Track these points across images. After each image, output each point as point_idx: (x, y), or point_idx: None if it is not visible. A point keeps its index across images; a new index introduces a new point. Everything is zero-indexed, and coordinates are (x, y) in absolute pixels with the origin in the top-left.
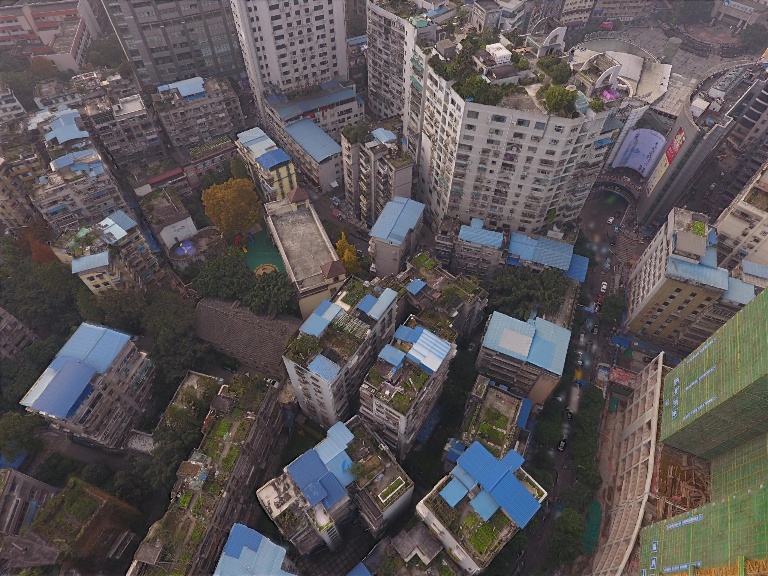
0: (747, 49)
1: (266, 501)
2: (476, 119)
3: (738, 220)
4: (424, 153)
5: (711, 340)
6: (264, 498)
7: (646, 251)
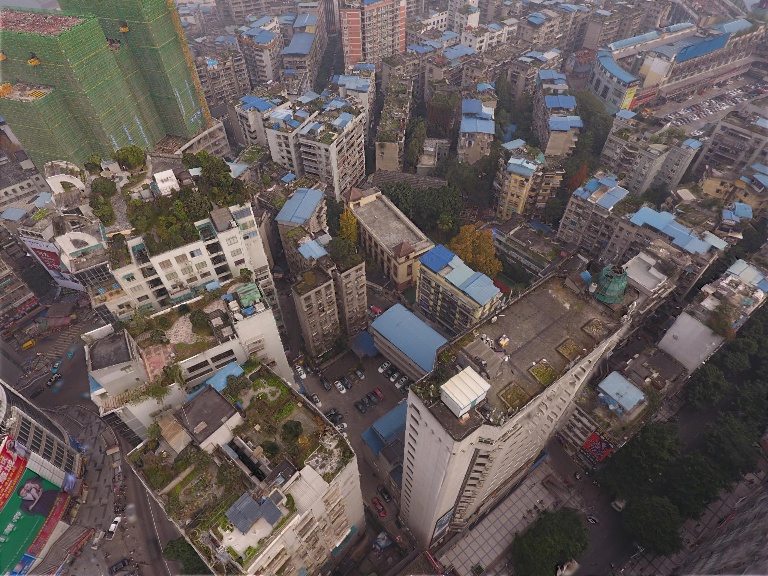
0: None
1: (358, 99)
2: None
3: None
4: None
5: None
6: (360, 99)
7: None
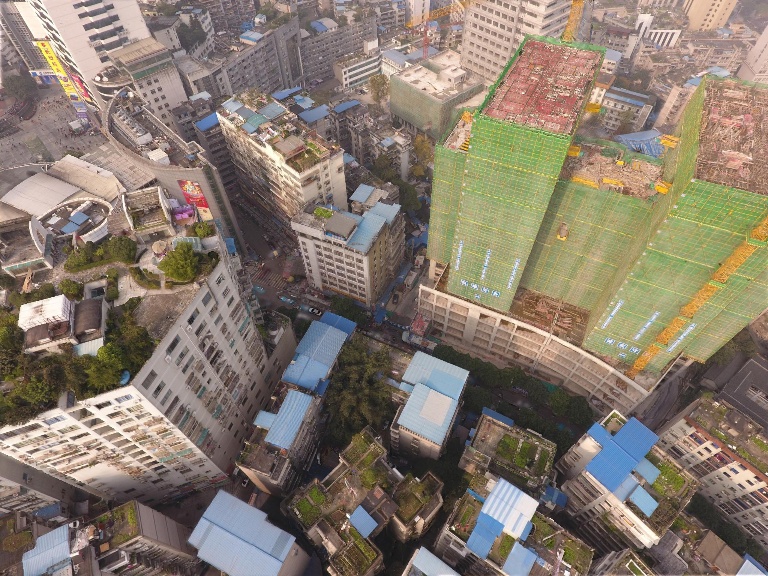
0: (31, 100)
1: None
2: (156, 377)
3: (309, 185)
4: (99, 480)
5: (459, 245)
6: None
7: (308, 262)
